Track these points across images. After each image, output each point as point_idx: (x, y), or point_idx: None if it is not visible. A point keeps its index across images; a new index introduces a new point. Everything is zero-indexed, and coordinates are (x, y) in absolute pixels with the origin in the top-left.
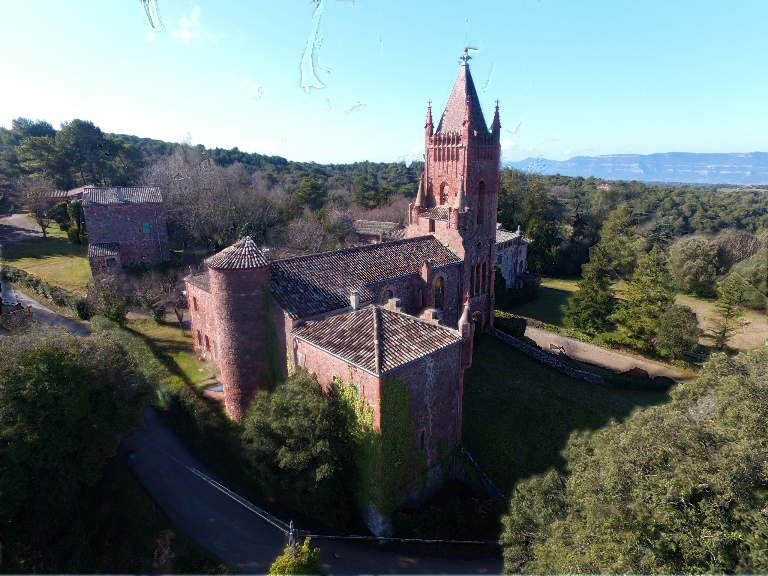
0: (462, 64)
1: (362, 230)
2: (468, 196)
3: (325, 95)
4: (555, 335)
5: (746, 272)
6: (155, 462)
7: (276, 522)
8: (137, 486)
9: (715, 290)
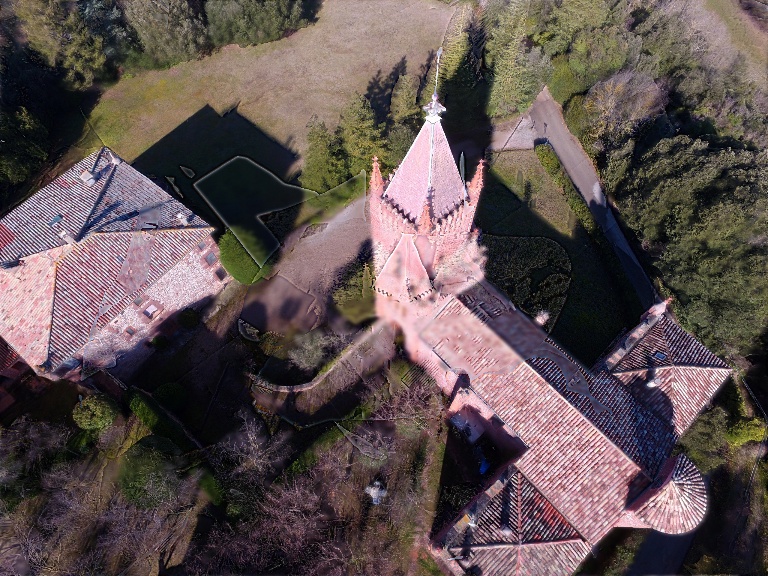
0: (436, 121)
1: None
2: None
3: None
4: None
5: (233, 12)
6: (658, 571)
7: (767, 433)
8: (683, 572)
9: (212, 43)
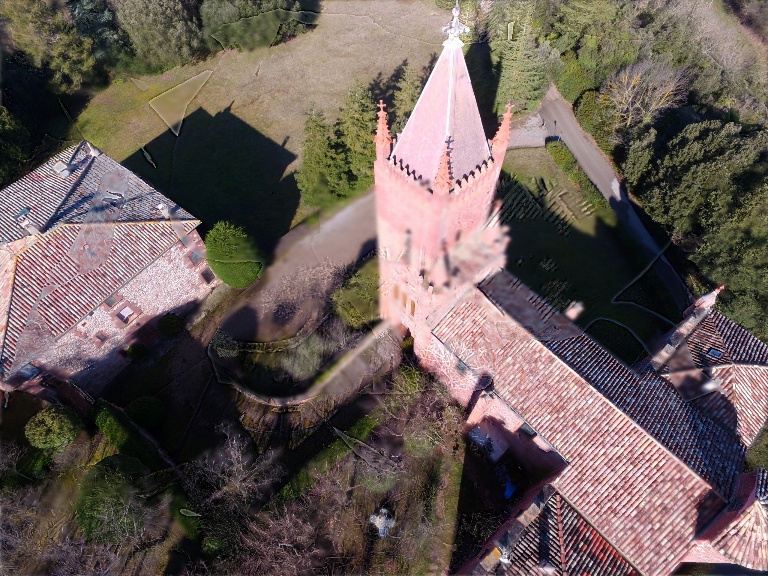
0: None
1: None
2: None
3: None
4: None
5: (229, 15)
6: None
7: None
8: None
9: (207, 47)
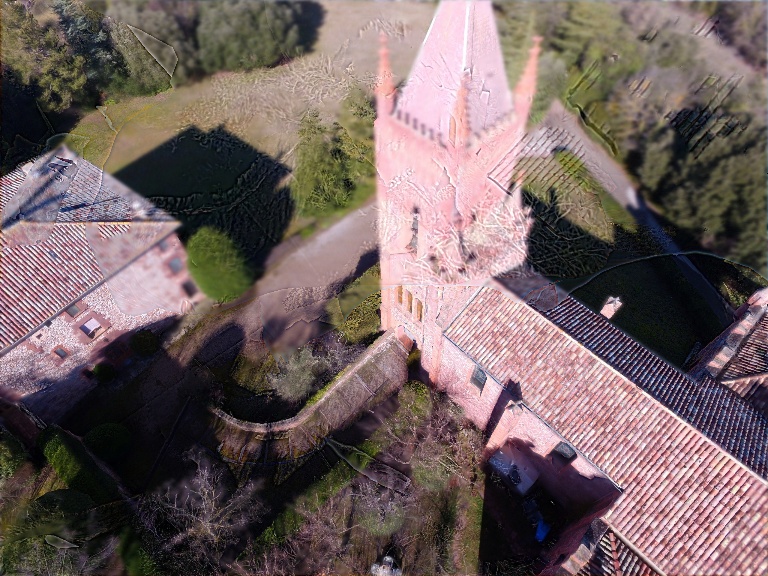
0: None
1: None
2: None
3: (354, 289)
4: None
5: None
6: None
7: None
8: None
9: None
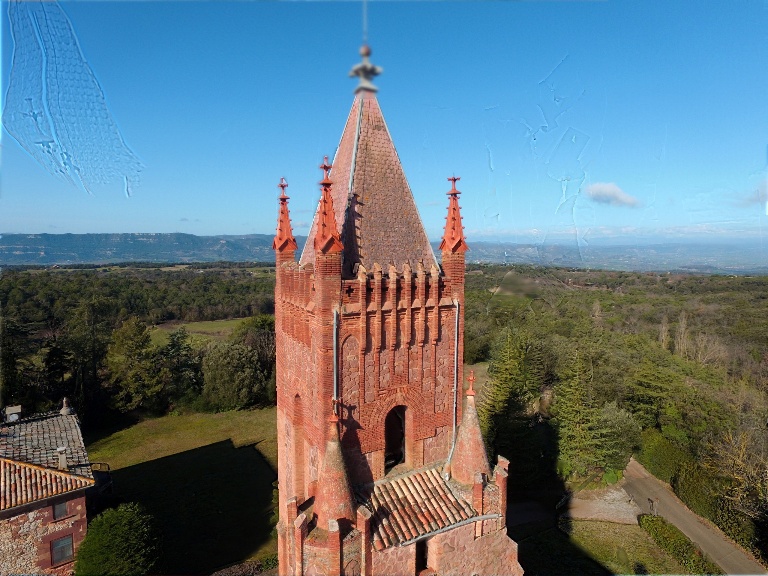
0: None
1: None
2: None
3: None
4: None
5: None
6: None
7: None
8: None
9: (267, 396)
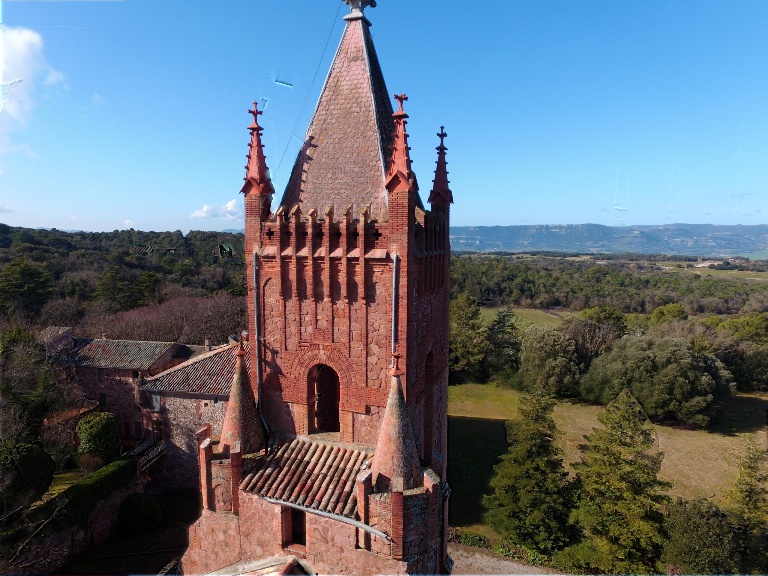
0: None
1: (103, 360)
2: (409, 413)
3: None
4: (485, 557)
5: (613, 371)
6: None
7: None
8: None
9: (580, 391)
